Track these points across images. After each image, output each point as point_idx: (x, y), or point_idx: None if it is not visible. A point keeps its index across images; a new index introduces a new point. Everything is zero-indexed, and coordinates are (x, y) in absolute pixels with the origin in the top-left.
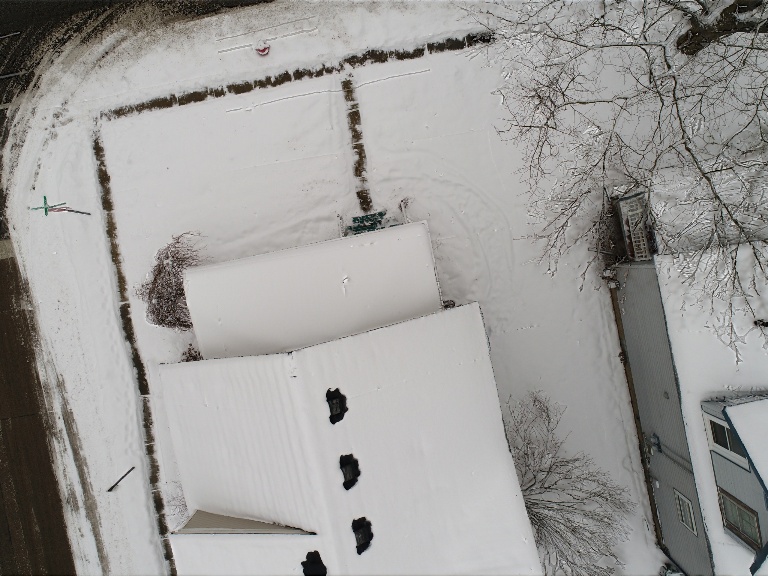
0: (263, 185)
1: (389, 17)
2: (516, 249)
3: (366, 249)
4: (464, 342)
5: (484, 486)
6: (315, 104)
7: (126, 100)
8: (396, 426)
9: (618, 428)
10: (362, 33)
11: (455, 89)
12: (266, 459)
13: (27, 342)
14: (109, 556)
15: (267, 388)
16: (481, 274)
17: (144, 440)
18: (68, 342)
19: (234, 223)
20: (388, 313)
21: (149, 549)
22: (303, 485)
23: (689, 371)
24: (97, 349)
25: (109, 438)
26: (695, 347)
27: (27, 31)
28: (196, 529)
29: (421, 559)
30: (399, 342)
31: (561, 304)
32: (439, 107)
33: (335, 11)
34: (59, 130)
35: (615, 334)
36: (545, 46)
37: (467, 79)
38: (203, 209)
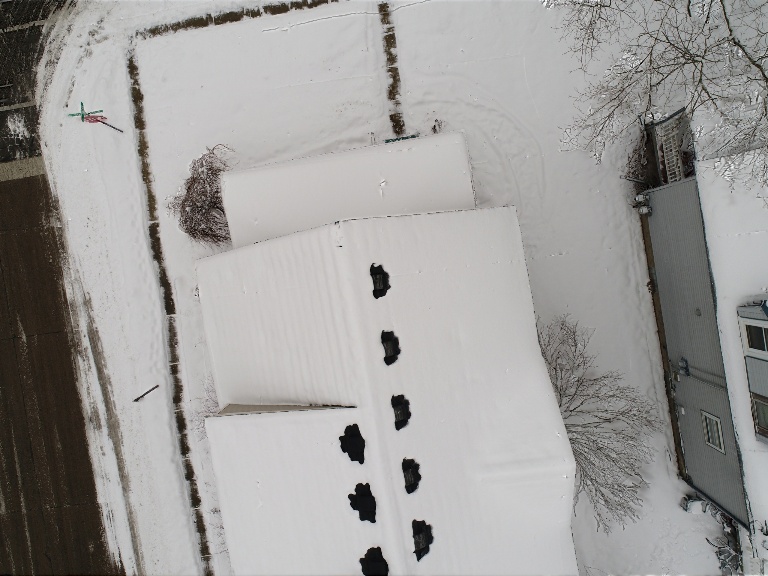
0: (297, 105)
1: None
2: (547, 176)
3: (404, 154)
4: (502, 242)
5: (517, 385)
6: (351, 25)
7: (162, 19)
8: (435, 312)
9: (644, 357)
10: None
11: (492, 13)
12: (306, 337)
13: (55, 259)
14: (130, 475)
15: (311, 262)
16: (512, 200)
17: (169, 360)
18: (96, 260)
19: (266, 142)
20: None
21: (170, 467)
22: (344, 358)
23: (726, 276)
24: (125, 267)
25: (134, 356)
26: (734, 251)
27: None
28: (231, 413)
29: (456, 446)
30: (440, 230)
31: (591, 232)
32: (475, 31)
33: None
34: (94, 48)
35: (644, 263)
36: None
37: (504, 4)
38: (236, 128)
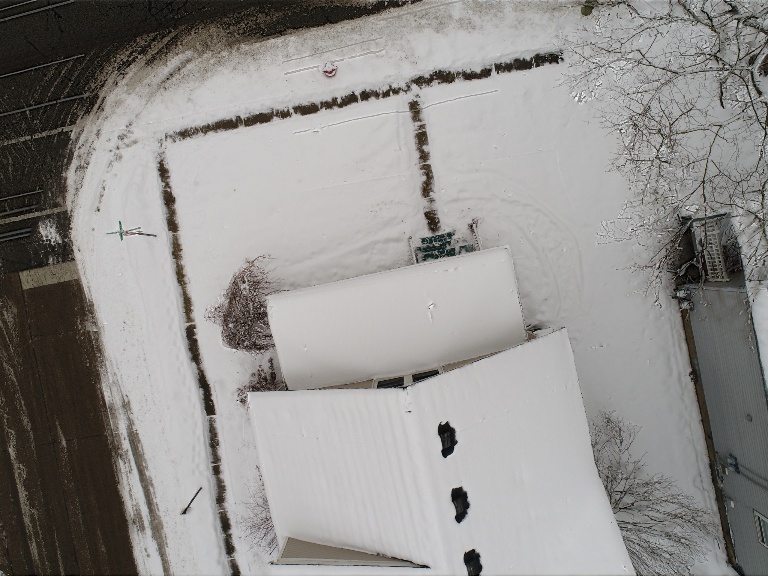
0: (331, 206)
1: (457, 38)
2: (585, 269)
3: (450, 275)
4: (556, 369)
5: (578, 513)
6: (383, 125)
7: (191, 122)
8: (500, 457)
9: (689, 447)
10: (429, 54)
11: (524, 109)
12: (373, 491)
13: (92, 363)
14: (175, 575)
15: (377, 422)
16: (551, 294)
17: (210, 460)
18: (134, 363)
19: (302, 244)
20: (475, 339)
21: (217, 569)
22: (416, 519)
23: None
24: (163, 370)
25: (176, 459)
26: None
27: (91, 53)
28: (296, 559)
29: None
30: (500, 372)
31: (631, 323)
32: (508, 127)
33: (402, 32)
34: (124, 152)
35: (685, 353)
36: (638, 74)
37: (536, 99)
38: (271, 230)
